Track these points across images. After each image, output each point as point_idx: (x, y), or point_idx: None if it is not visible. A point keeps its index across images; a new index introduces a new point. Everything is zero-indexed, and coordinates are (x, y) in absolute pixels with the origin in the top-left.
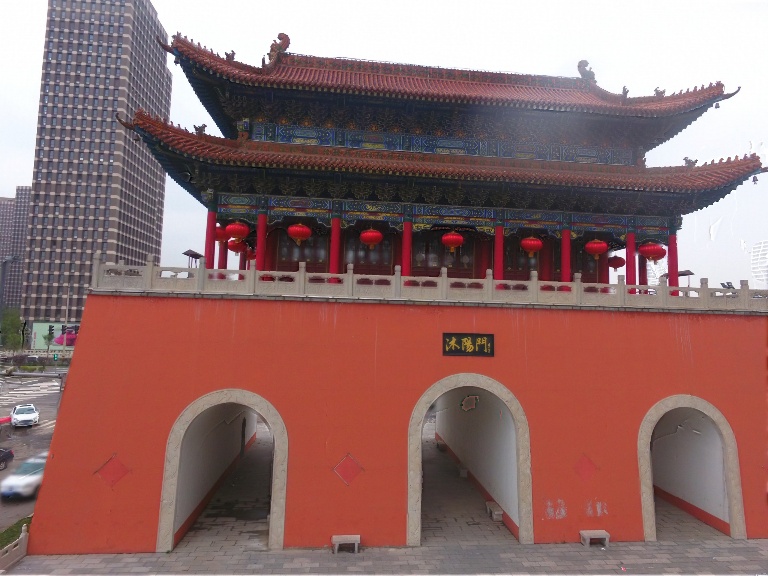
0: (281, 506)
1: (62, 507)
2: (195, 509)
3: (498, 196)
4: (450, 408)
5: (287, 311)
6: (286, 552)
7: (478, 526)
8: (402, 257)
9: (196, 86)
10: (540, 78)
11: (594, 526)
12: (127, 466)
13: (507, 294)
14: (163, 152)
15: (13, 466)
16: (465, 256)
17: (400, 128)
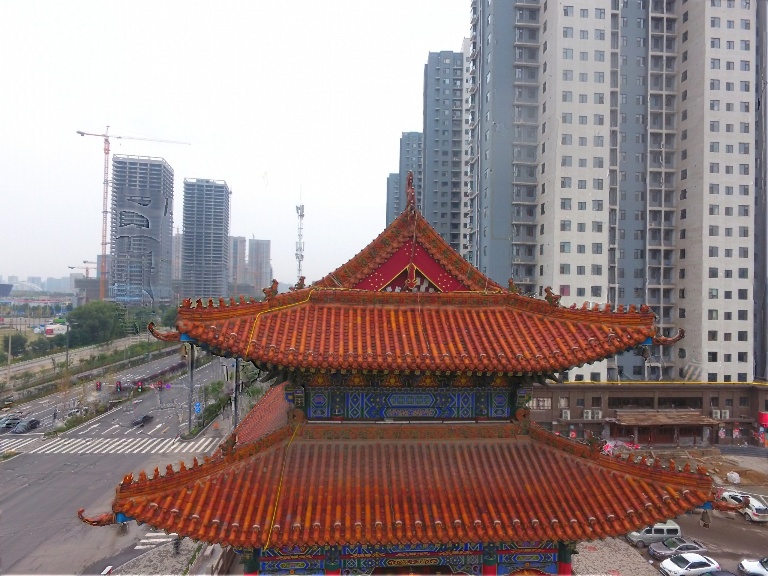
0: None
1: None
2: None
3: None
4: None
5: None
6: None
7: None
8: None
9: None
10: None
11: None
12: None
13: None
14: None
15: None
16: None
17: None
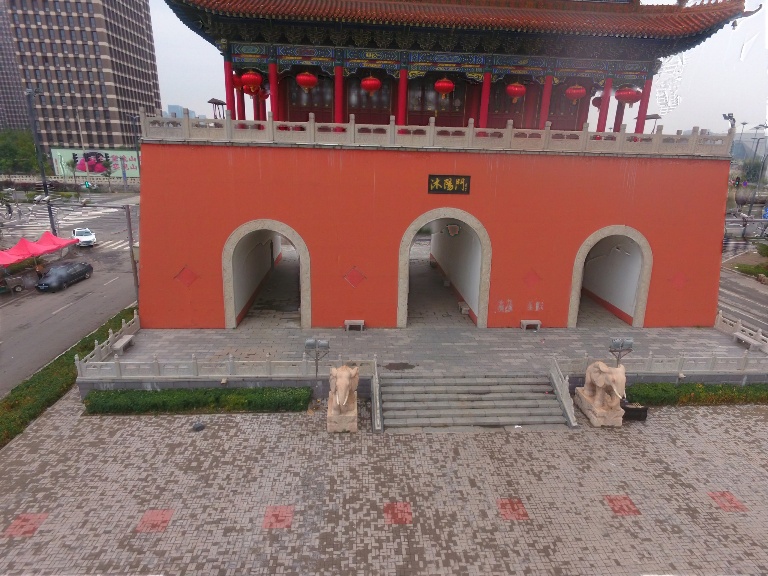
0: (308, 301)
1: (157, 300)
2: (246, 304)
3: (488, 42)
4: (441, 234)
5: (302, 157)
6: (314, 330)
7: (450, 317)
8: (398, 104)
9: None
10: None
11: (532, 317)
12: (196, 273)
13: (485, 141)
14: (177, 4)
15: (95, 276)
16: (457, 100)
17: None
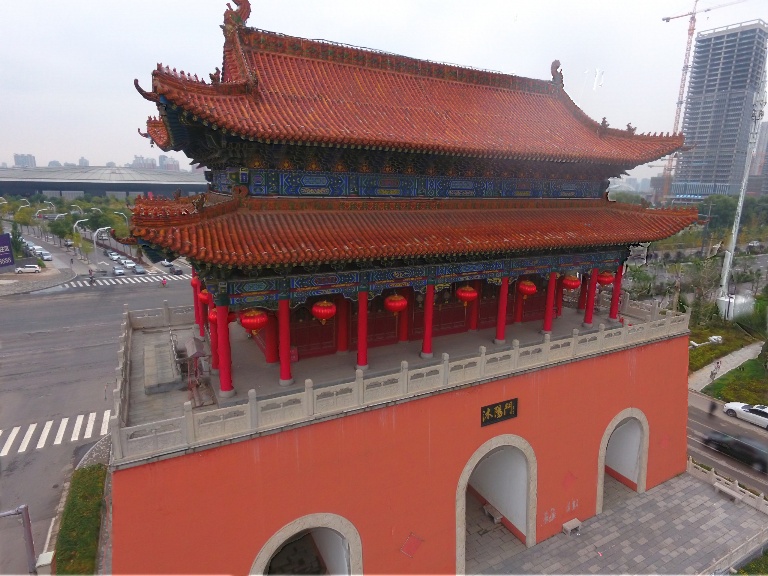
0: None
1: None
2: None
3: None
4: None
5: (349, 425)
6: None
7: (488, 535)
8: (425, 320)
9: (174, 129)
10: (520, 80)
11: (570, 517)
12: None
13: (527, 359)
14: None
15: None
16: None
17: (414, 168)
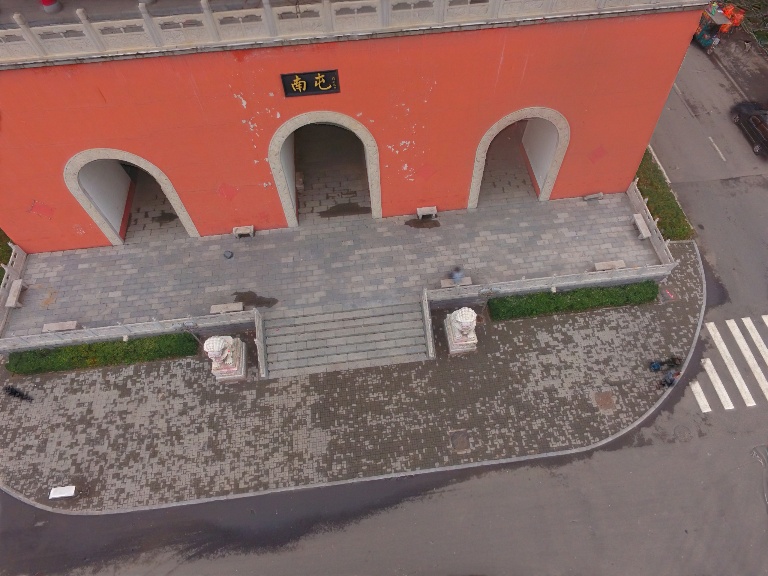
0: None
1: None
2: None
3: None
4: None
5: None
6: None
7: None
8: None
9: None
10: None
11: None
12: None
13: None
14: None
15: (759, 161)
16: None
17: None
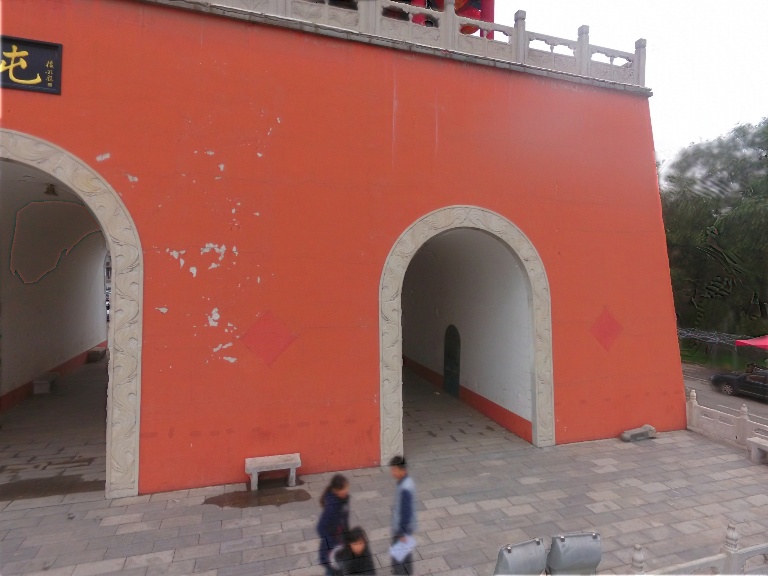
0: None
1: None
2: None
3: None
4: None
5: None
6: None
7: None
8: None
9: None
10: None
11: None
12: None
13: None
14: None
15: None
16: None
17: None
